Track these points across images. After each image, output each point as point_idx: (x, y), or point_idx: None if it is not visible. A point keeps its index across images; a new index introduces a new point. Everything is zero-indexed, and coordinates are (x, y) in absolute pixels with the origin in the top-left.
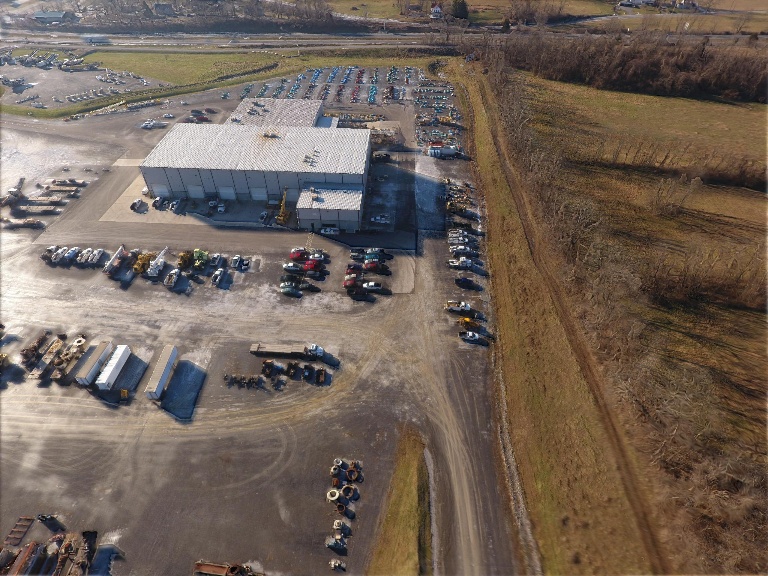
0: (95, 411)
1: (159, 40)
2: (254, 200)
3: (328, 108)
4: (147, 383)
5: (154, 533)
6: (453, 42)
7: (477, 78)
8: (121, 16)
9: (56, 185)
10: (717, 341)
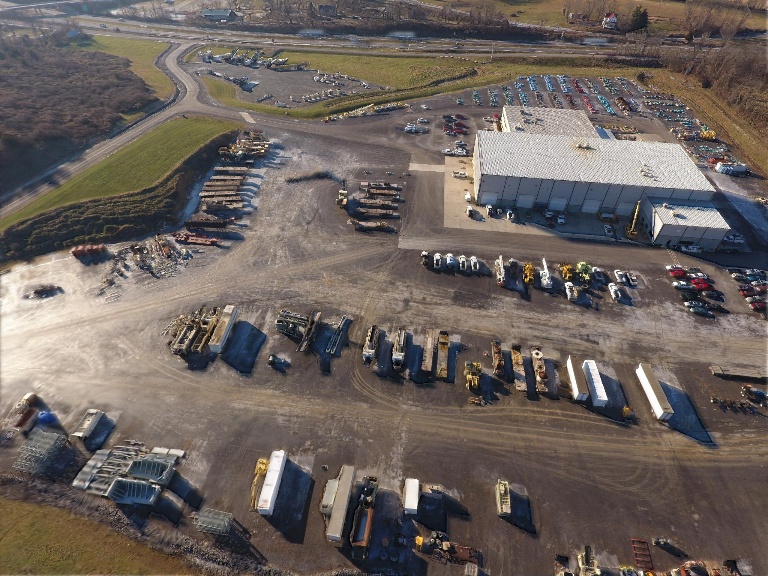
0: (609, 429)
1: (336, 41)
2: (582, 212)
3: None
4: (636, 402)
5: None
6: (648, 53)
7: (700, 92)
8: (285, 16)
9: (371, 188)
10: None
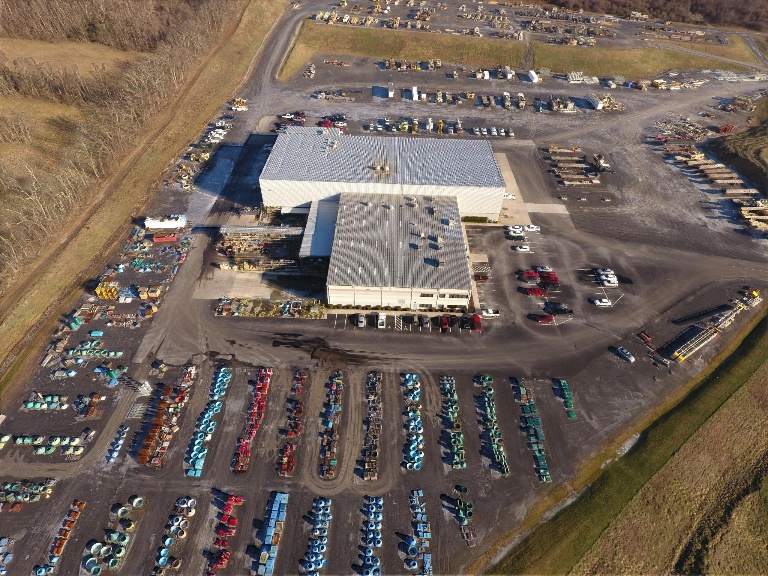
0: None
1: None
2: None
3: (322, 339)
4: None
5: (370, 70)
6: None
7: None
8: None
9: None
10: (120, 79)
